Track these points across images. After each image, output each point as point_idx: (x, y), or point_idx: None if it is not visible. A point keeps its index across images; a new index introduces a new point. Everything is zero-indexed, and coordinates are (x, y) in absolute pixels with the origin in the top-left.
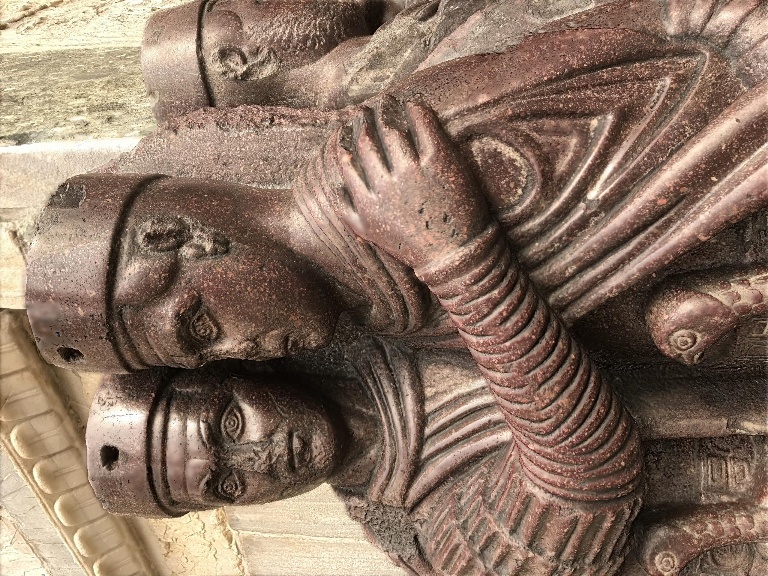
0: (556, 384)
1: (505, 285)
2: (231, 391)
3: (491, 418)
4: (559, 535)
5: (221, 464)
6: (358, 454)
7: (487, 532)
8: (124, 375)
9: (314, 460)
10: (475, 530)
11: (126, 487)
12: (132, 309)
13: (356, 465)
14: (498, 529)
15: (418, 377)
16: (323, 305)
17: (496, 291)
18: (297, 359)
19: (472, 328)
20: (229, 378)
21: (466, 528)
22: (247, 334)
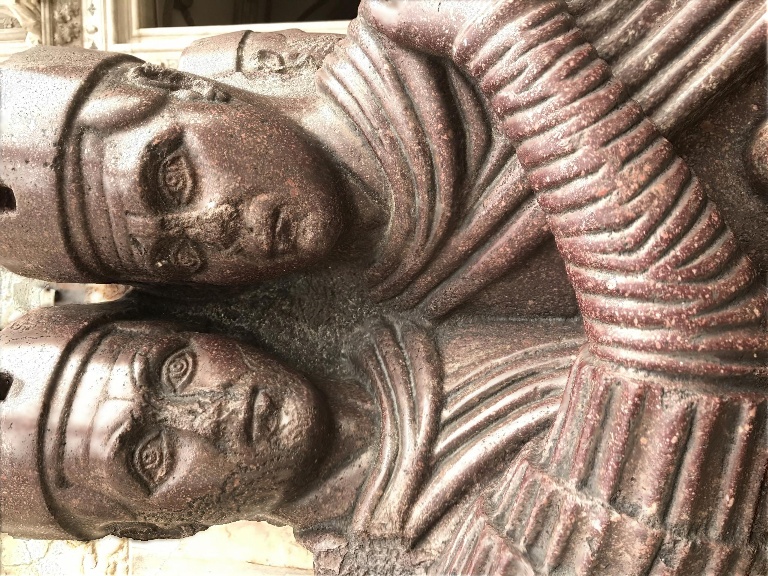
0: (646, 162)
1: (571, 34)
2: (188, 338)
3: (537, 384)
4: (663, 455)
5: (148, 412)
6: (343, 460)
7: (538, 499)
8: (57, 308)
9: (281, 432)
10: (517, 515)
11: (4, 435)
12: (95, 134)
13: (338, 477)
14: (557, 485)
15: (437, 351)
16: (329, 186)
17: (560, 38)
18: (280, 350)
19: (527, 92)
20: (189, 331)
21: (501, 524)
22: (228, 191)
